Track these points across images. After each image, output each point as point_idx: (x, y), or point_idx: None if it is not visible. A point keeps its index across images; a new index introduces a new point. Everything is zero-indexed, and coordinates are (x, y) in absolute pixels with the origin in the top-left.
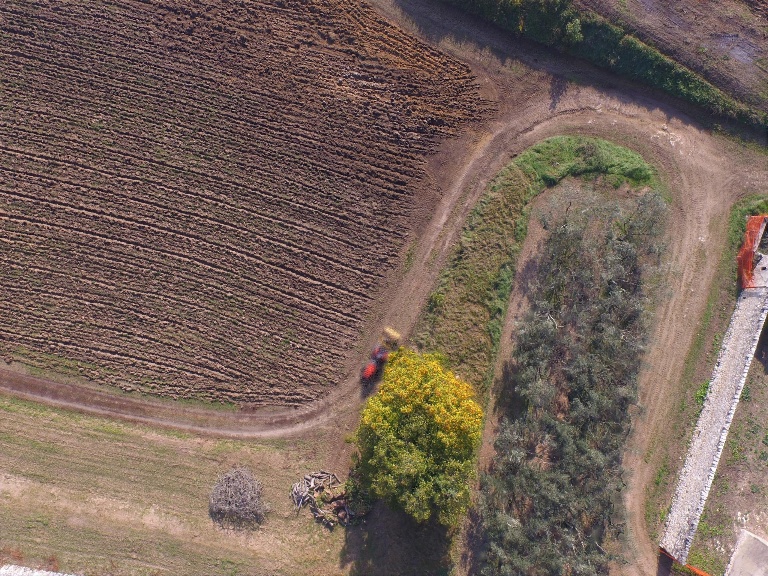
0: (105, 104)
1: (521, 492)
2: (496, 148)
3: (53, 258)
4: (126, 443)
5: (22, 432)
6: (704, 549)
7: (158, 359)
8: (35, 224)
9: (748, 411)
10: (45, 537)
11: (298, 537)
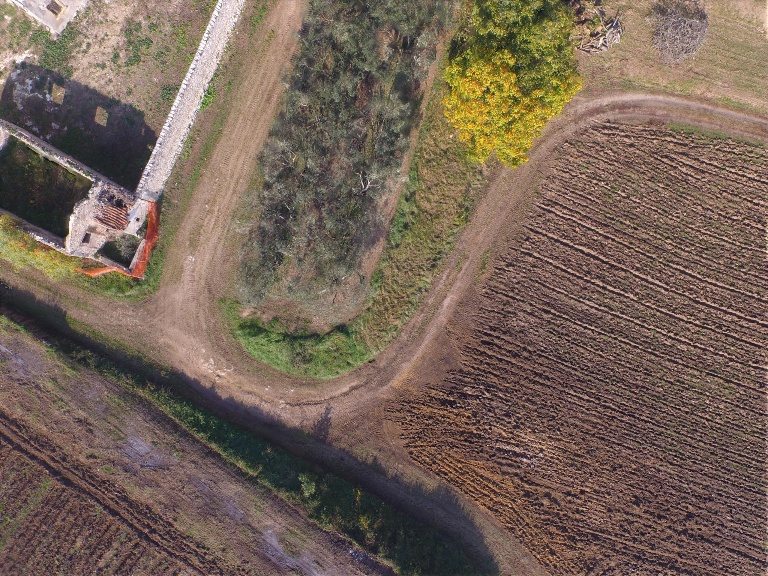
0: None
1: (421, 2)
2: (388, 371)
3: None
4: None
5: None
6: None
7: (745, 181)
8: None
9: (165, 75)
10: None
11: None
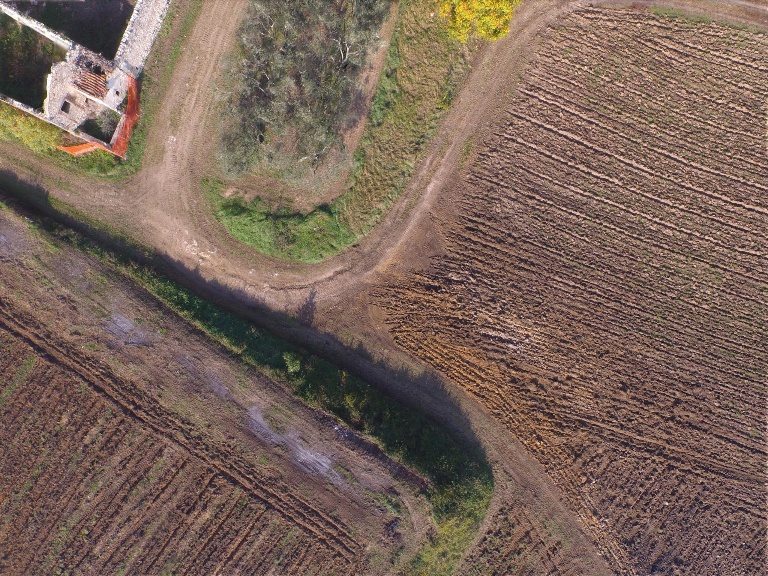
0: None
1: None
2: (373, 257)
3: None
4: None
5: None
6: None
7: (729, 64)
8: None
9: None
10: None
11: None
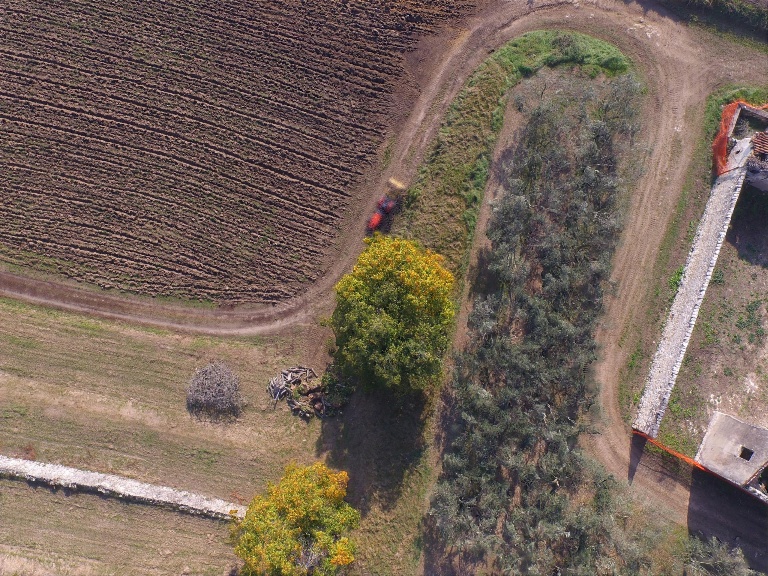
0: (84, 3)
1: (492, 363)
2: (474, 44)
3: (32, 156)
4: (104, 339)
5: (0, 327)
6: (677, 430)
7: (136, 256)
8: (14, 122)
9: (721, 295)
10: (22, 427)
11: (275, 429)
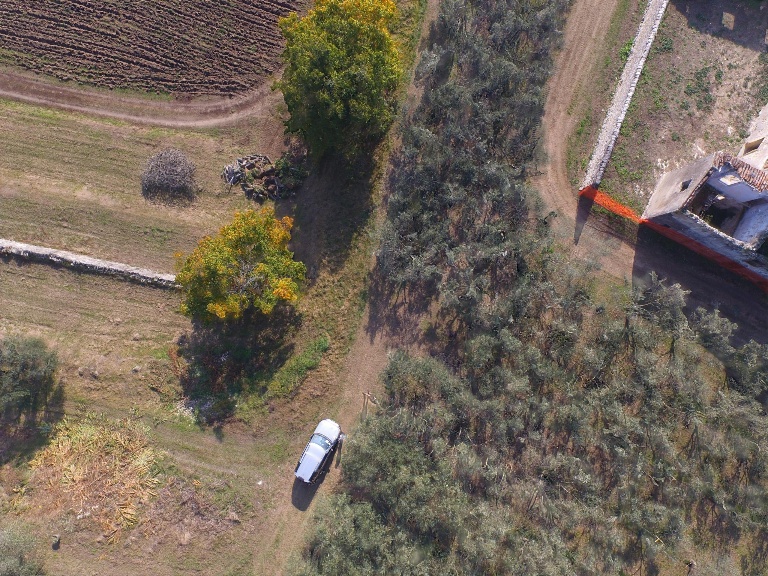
0: None
1: (436, 103)
2: None
3: None
4: (61, 127)
5: None
6: (623, 192)
7: (94, 48)
8: None
9: (670, 62)
10: None
11: (228, 212)
